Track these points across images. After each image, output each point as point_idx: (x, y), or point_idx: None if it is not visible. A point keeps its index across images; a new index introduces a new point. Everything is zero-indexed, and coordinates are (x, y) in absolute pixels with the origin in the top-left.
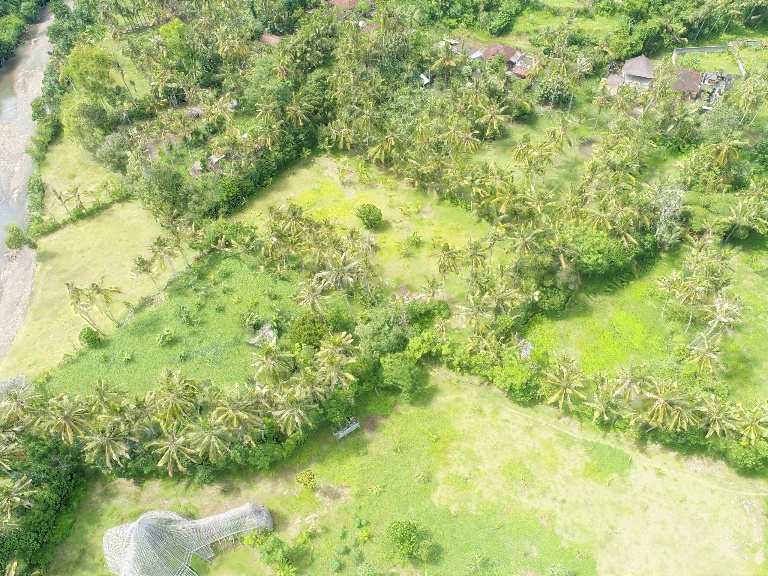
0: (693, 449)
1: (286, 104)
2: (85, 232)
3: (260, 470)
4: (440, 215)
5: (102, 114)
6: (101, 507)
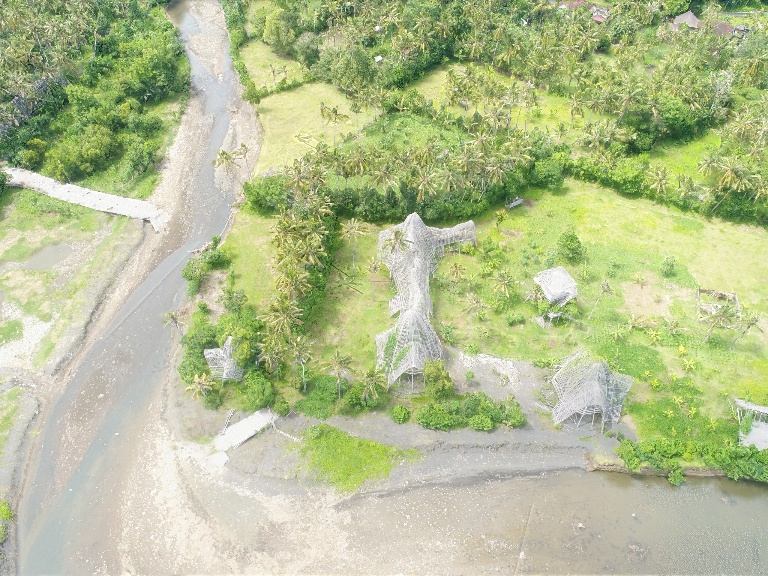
0: (743, 220)
1: (435, 21)
2: (289, 99)
3: (460, 221)
4: (551, 101)
5: (295, 20)
6: None
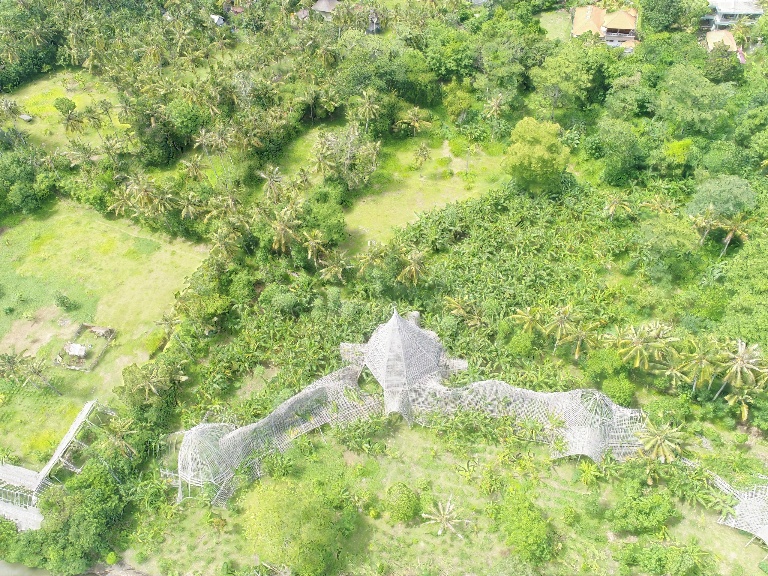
0: (203, 239)
1: (25, 28)
2: None
3: None
4: None
5: None
6: None
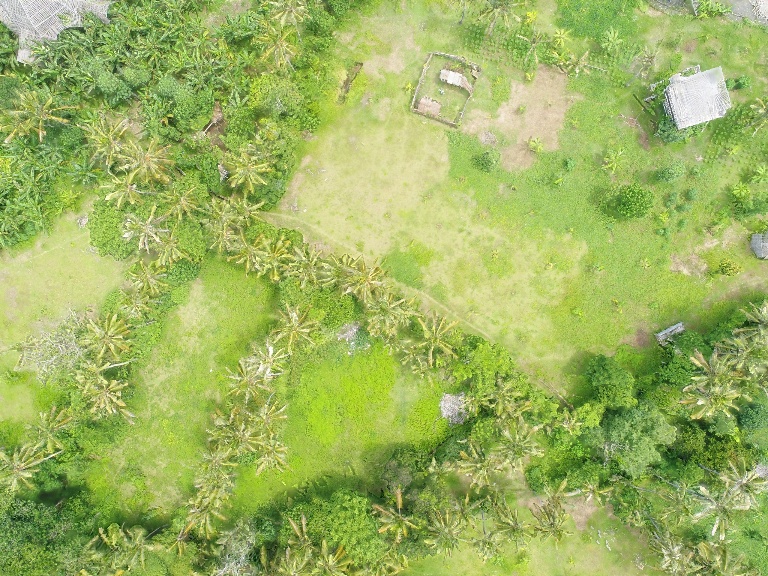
0: None
1: None
2: None
3: None
4: None
5: None
6: None
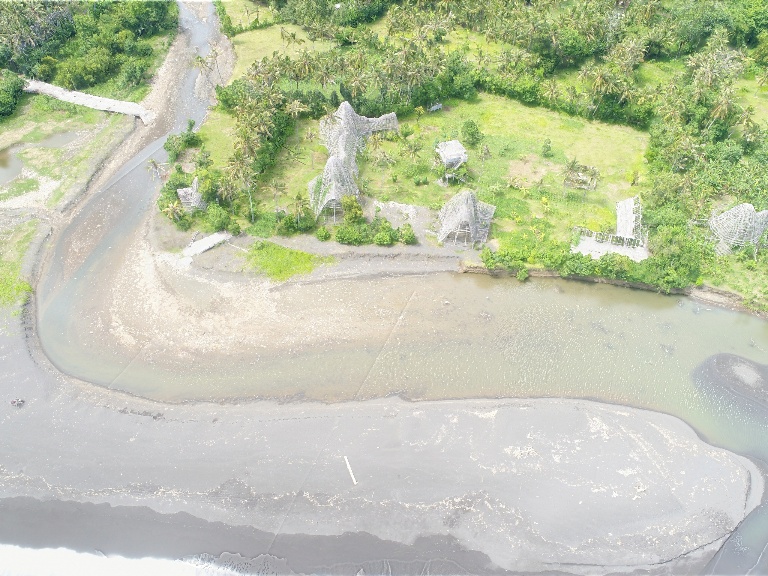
0: (616, 122)
1: None
2: (260, 35)
3: None
4: (480, 40)
5: None
6: (306, 128)
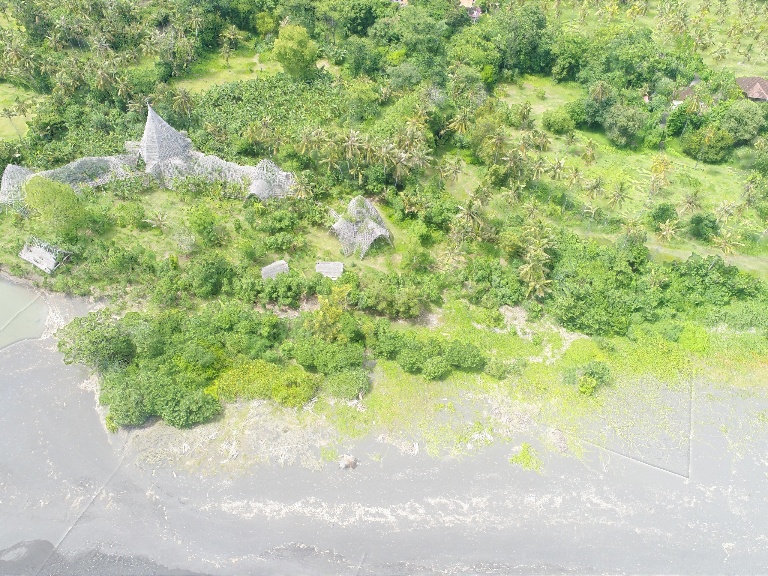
0: None
1: None
2: None
3: None
4: None
5: None
6: None
